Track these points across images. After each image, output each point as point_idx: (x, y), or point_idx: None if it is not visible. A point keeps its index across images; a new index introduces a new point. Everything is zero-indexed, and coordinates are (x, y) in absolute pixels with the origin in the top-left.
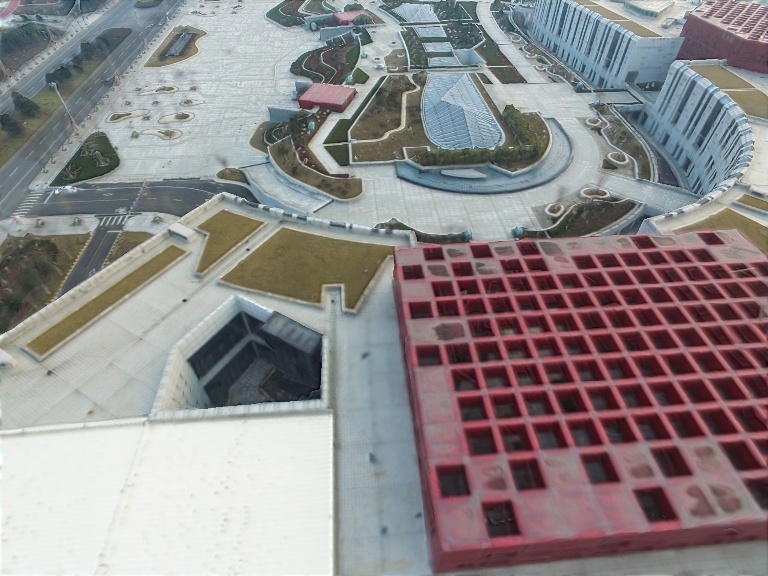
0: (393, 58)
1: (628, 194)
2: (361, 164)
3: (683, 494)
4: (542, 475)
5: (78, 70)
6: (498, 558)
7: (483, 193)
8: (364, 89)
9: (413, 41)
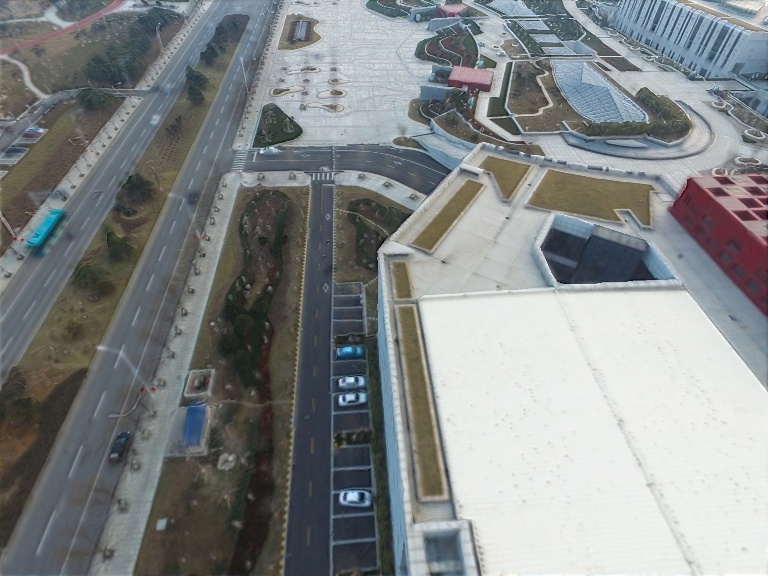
0: (509, 47)
1: None
2: (531, 134)
3: None
4: None
5: (222, 50)
6: None
7: (650, 159)
8: (497, 73)
9: (522, 32)
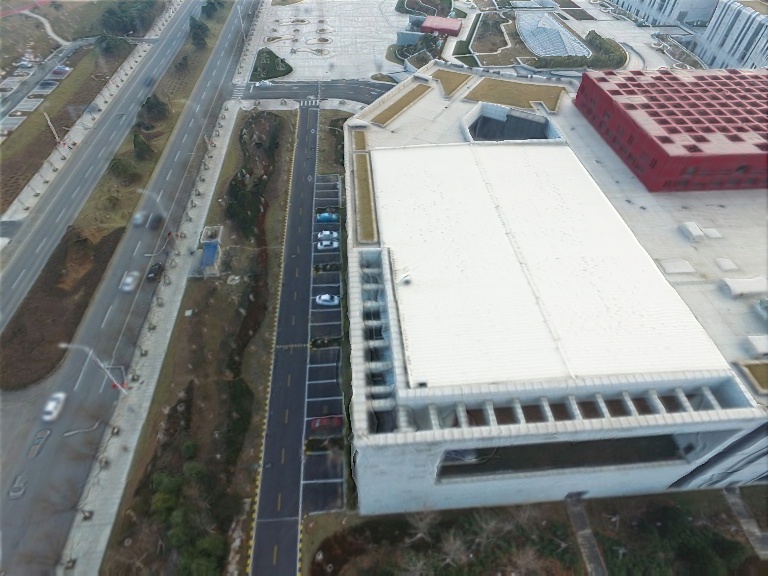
0: (480, 1)
1: None
2: (488, 67)
3: None
4: (707, 139)
5: (221, 6)
6: (685, 179)
7: None
8: (467, 22)
9: None
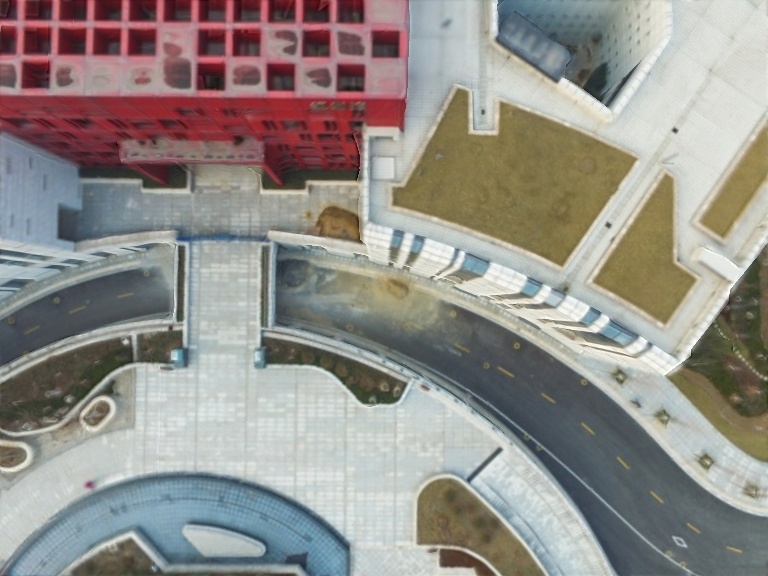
0: None
1: None
2: None
3: None
4: None
5: None
6: None
7: (204, 477)
8: None
9: None
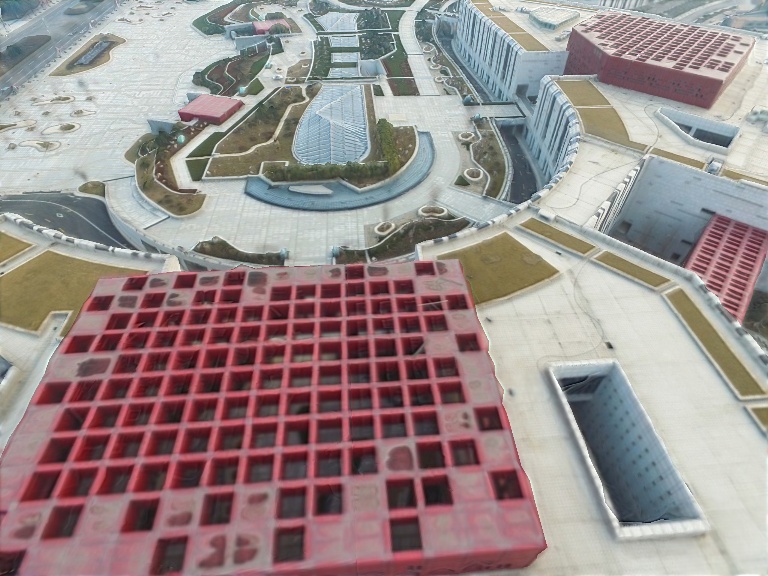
0: (297, 68)
1: (467, 212)
2: (213, 179)
3: (204, 544)
4: (77, 523)
5: None
6: None
7: (322, 210)
8: (253, 101)
9: (322, 51)
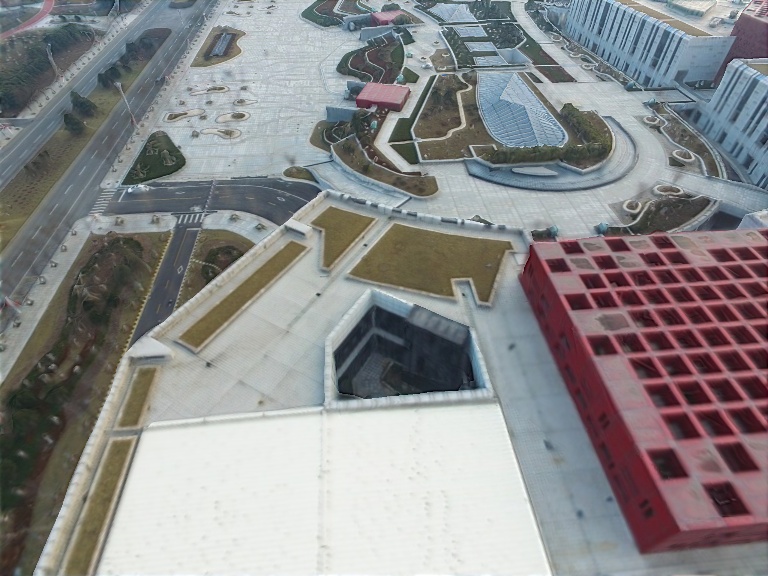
0: (438, 57)
1: (701, 191)
2: (431, 162)
3: None
4: (751, 458)
5: (127, 70)
6: (709, 538)
7: (557, 190)
8: (416, 88)
9: (456, 41)
